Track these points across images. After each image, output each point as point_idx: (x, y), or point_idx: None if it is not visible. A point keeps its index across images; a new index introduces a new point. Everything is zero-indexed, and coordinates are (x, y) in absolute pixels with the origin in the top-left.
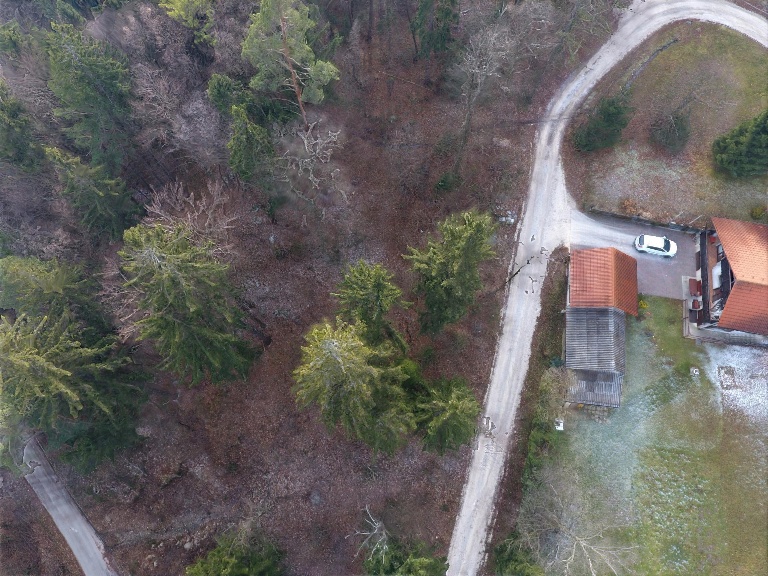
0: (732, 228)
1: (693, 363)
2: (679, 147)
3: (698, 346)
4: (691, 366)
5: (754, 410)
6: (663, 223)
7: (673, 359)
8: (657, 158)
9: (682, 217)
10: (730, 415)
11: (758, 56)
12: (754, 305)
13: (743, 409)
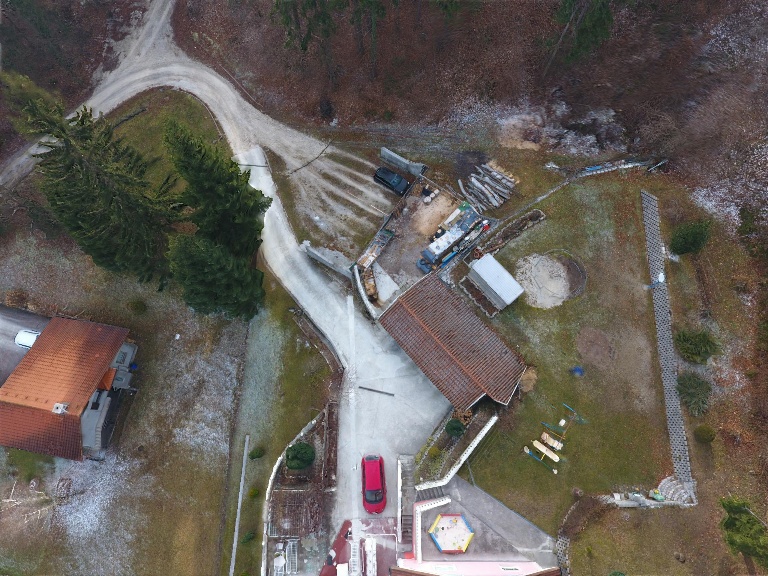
0: (61, 332)
1: (36, 474)
2: (68, 235)
3: (47, 455)
4: (33, 477)
5: (74, 529)
6: (50, 316)
7: (18, 469)
8: (57, 245)
9: (68, 310)
10: (54, 534)
11: (202, 130)
12: (23, 425)
13: (66, 527)
